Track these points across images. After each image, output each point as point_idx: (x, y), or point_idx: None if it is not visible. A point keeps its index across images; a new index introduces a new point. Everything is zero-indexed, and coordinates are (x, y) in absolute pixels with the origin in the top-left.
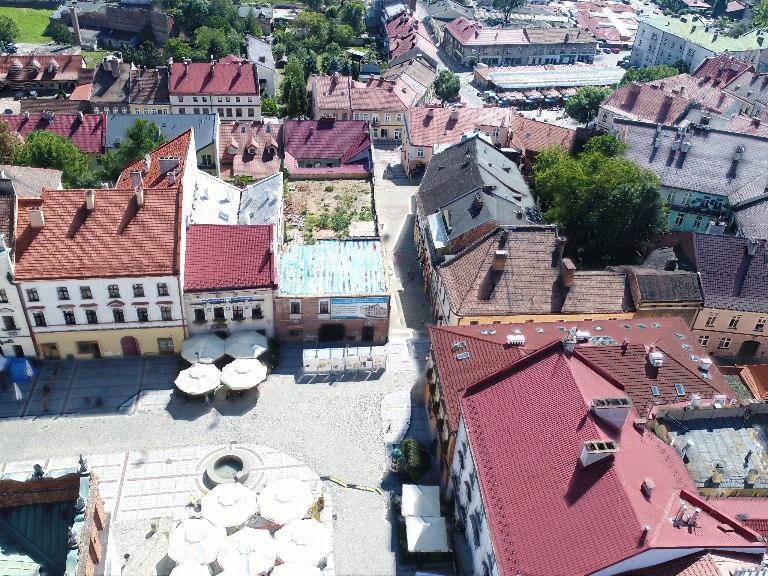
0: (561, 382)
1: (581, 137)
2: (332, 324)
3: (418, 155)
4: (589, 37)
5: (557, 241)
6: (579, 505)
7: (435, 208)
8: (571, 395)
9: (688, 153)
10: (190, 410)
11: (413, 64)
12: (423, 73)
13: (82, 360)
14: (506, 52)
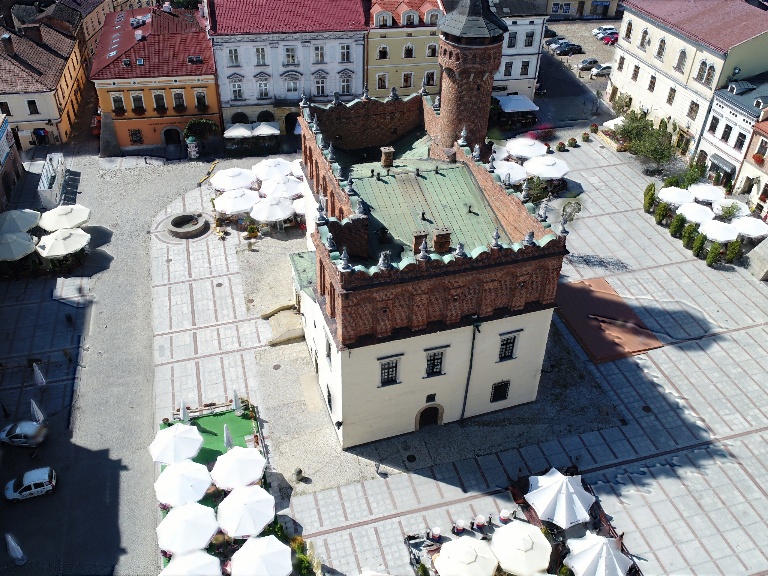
0: None
1: None
2: None
3: None
4: None
5: None
6: None
7: None
8: None
9: None
10: (97, 262)
11: None
12: None
13: None
14: None
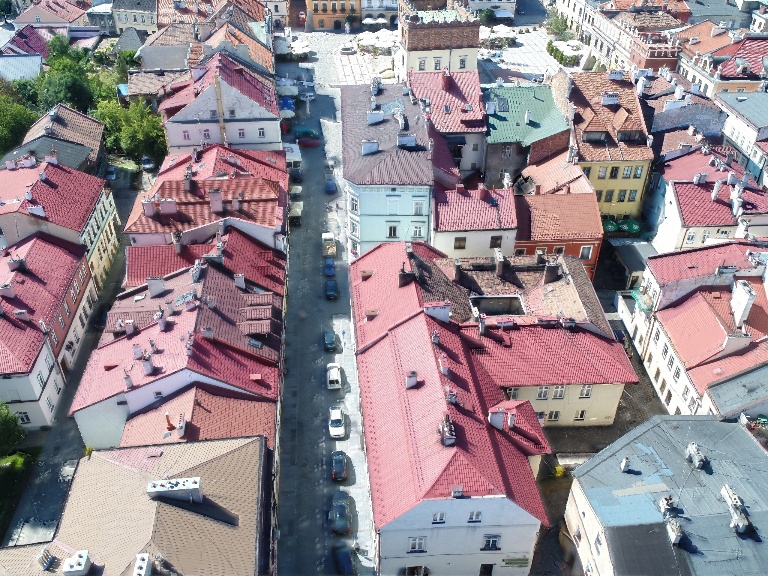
0: None
1: None
2: None
3: None
4: None
5: None
6: None
7: None
8: None
9: None
10: None
11: None
12: None
13: None
14: None
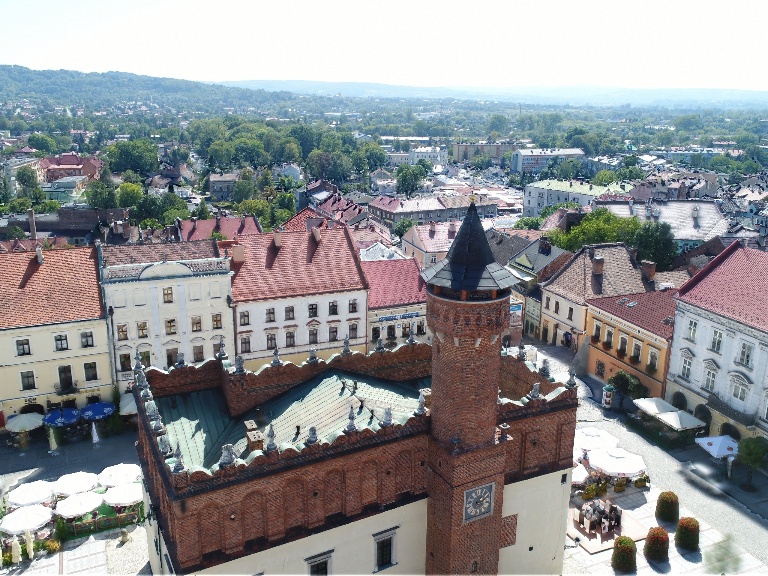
0: (759, 258)
1: (571, 220)
2: None
3: (432, 261)
4: (489, 201)
5: (629, 252)
6: None
7: None
8: None
9: (659, 217)
10: None
11: (370, 221)
12: (380, 227)
13: None
14: (428, 217)
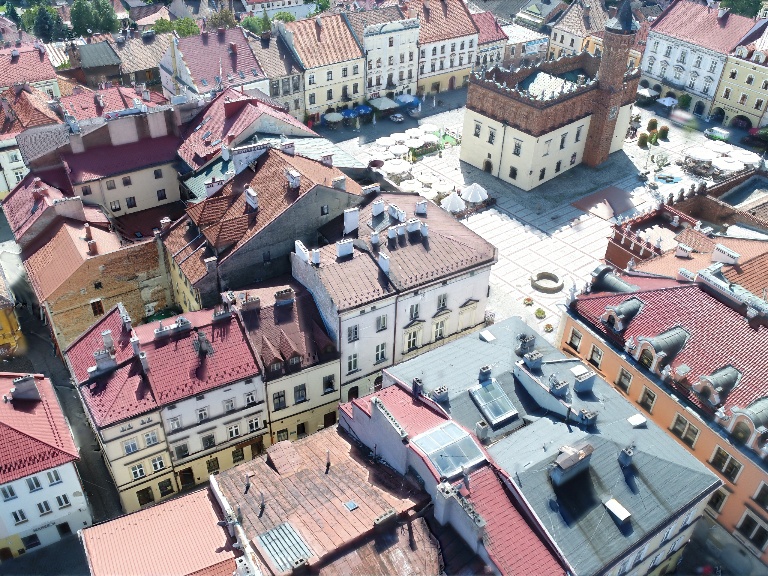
0: (690, 6)
1: None
2: (525, 59)
3: None
4: None
5: (601, 1)
6: (728, 26)
7: (509, 15)
8: (698, 7)
9: None
10: None
11: None
12: None
13: (433, 95)
14: None
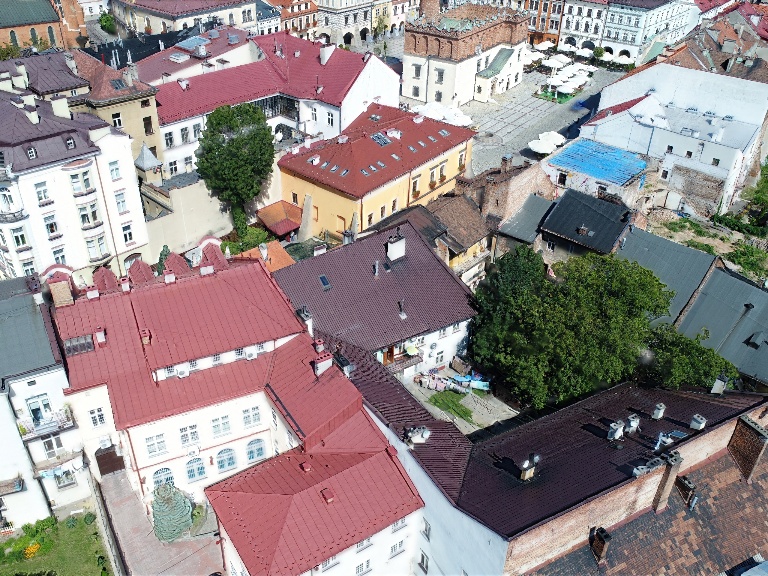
0: None
1: None
2: None
3: None
4: None
5: None
6: None
7: None
8: None
9: (605, 440)
10: None
11: None
12: None
13: None
14: None
